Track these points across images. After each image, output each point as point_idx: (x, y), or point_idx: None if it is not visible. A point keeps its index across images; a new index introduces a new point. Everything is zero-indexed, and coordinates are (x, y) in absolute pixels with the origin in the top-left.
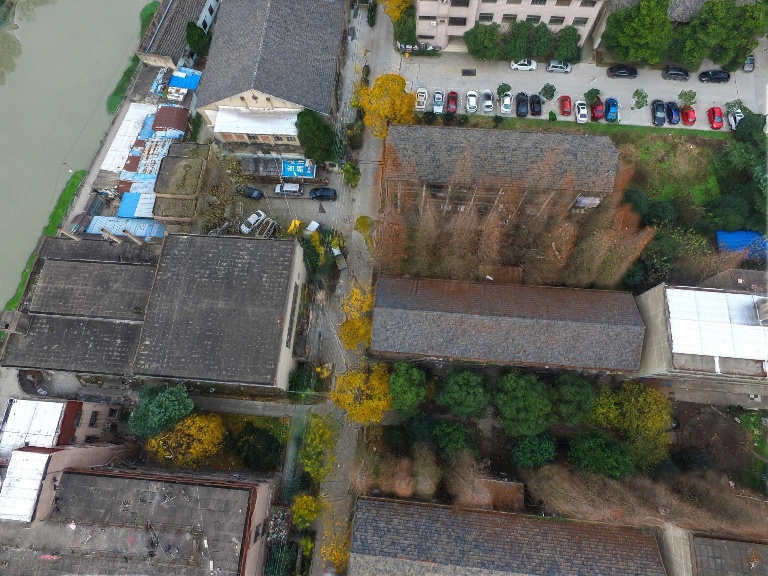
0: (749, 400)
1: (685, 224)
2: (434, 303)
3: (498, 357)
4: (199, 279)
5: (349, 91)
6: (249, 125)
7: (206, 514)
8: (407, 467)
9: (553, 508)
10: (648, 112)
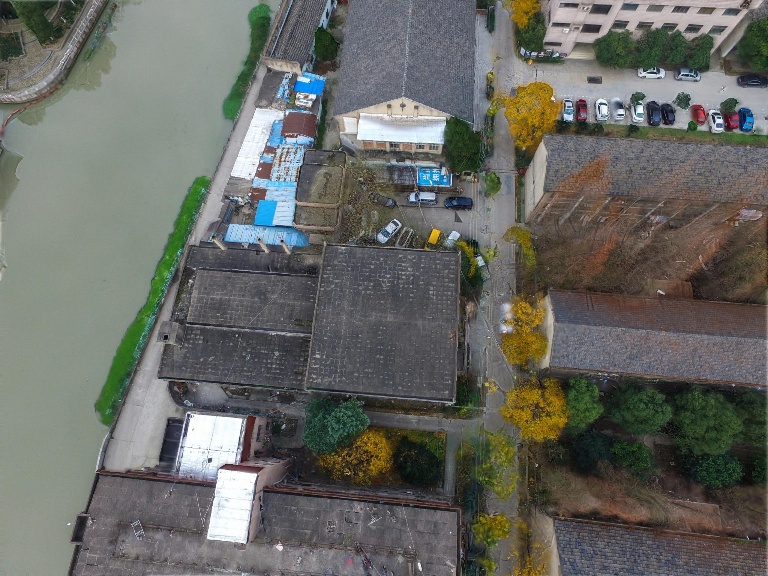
0: None
1: None
2: (616, 319)
3: (683, 374)
4: (364, 291)
5: (475, 98)
6: (393, 133)
7: (416, 536)
8: (590, 486)
9: (757, 531)
10: None
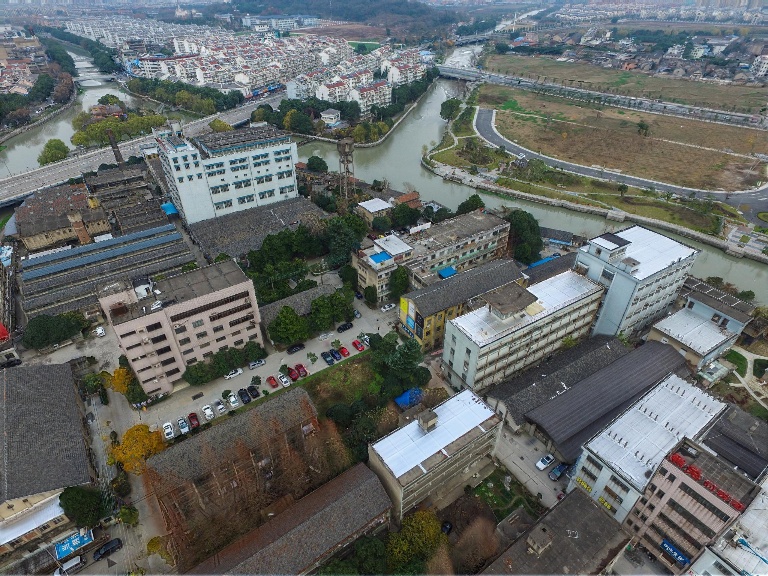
0: (474, 479)
1: (375, 406)
2: (236, 559)
3: (304, 564)
4: None
5: (103, 457)
6: (9, 533)
7: None
8: None
9: None
10: (322, 361)
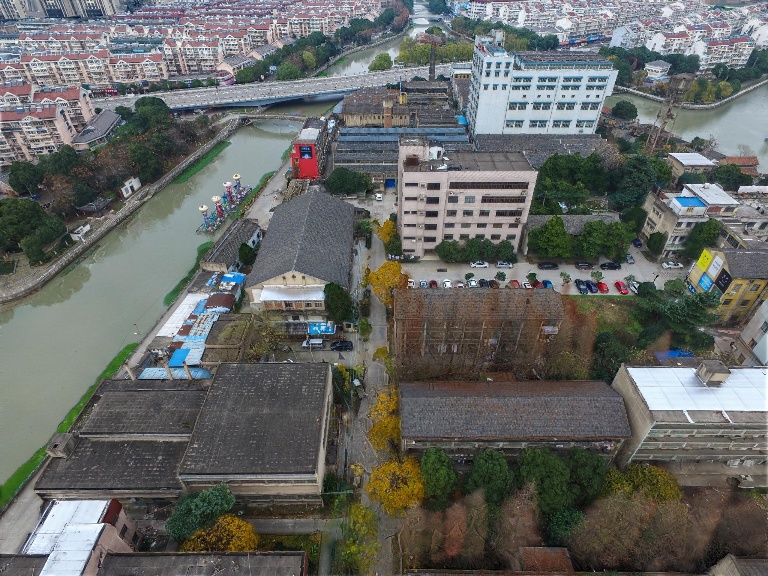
0: (742, 480)
1: (628, 347)
2: (450, 393)
3: (512, 434)
4: (246, 393)
5: (356, 283)
6: (287, 295)
7: None
8: None
9: (601, 563)
10: (574, 287)
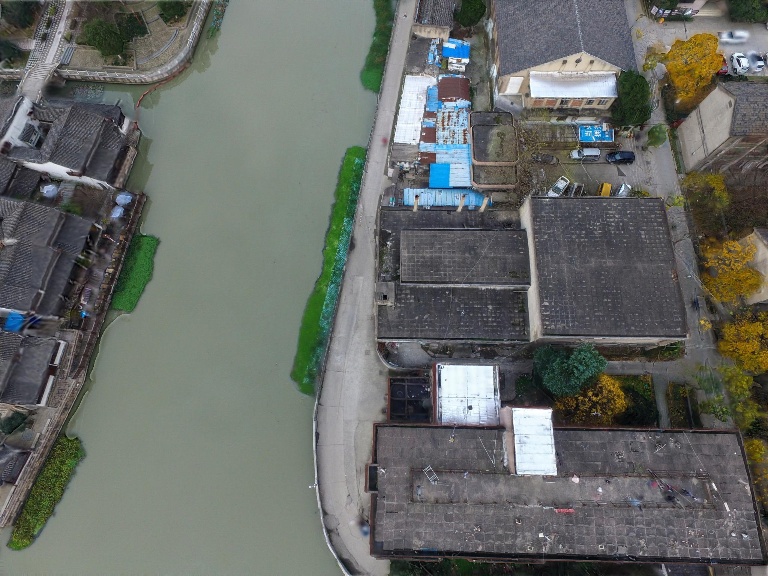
0: None
1: None
2: None
3: None
4: (577, 239)
5: None
6: (566, 89)
7: (703, 459)
8: None
9: None
10: None
